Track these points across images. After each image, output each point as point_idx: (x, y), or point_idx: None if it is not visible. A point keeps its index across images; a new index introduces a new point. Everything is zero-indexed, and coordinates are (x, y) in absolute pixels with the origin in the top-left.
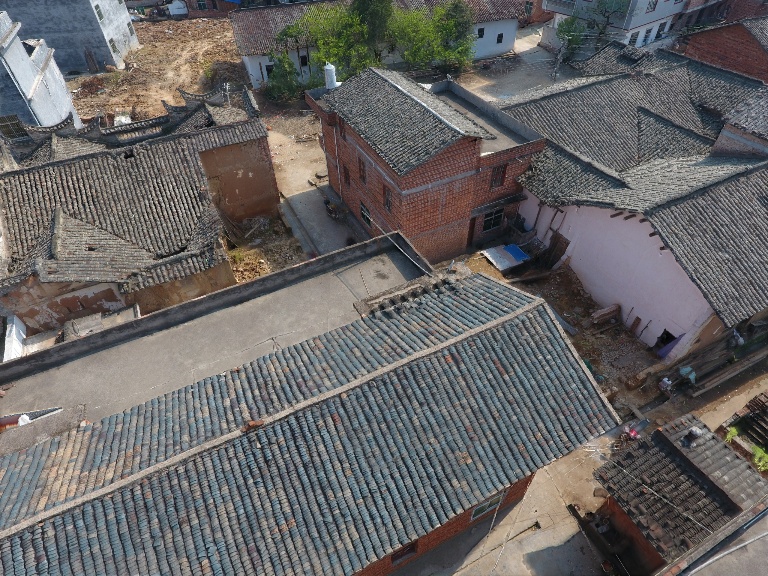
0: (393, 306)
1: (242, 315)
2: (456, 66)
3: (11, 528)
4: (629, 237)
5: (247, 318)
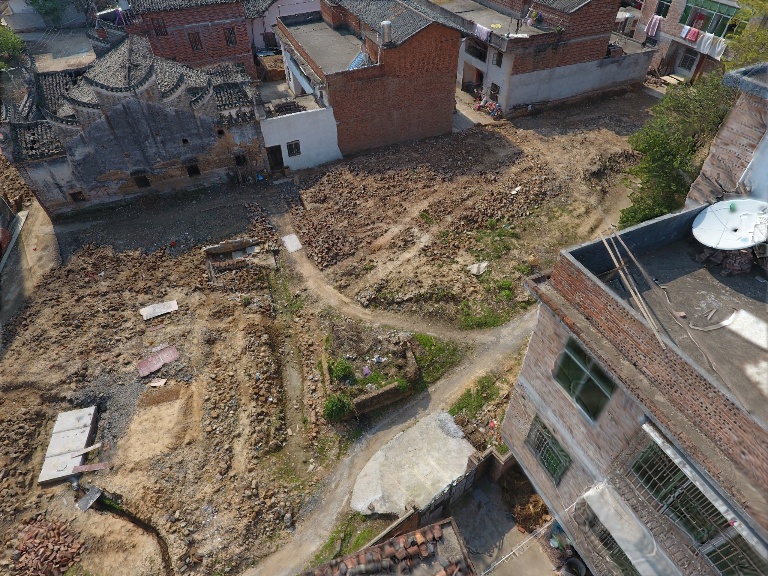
0: (336, 0)
1: (308, 48)
2: (8, 55)
3: (412, 8)
4: (295, 4)
5: (311, 47)
